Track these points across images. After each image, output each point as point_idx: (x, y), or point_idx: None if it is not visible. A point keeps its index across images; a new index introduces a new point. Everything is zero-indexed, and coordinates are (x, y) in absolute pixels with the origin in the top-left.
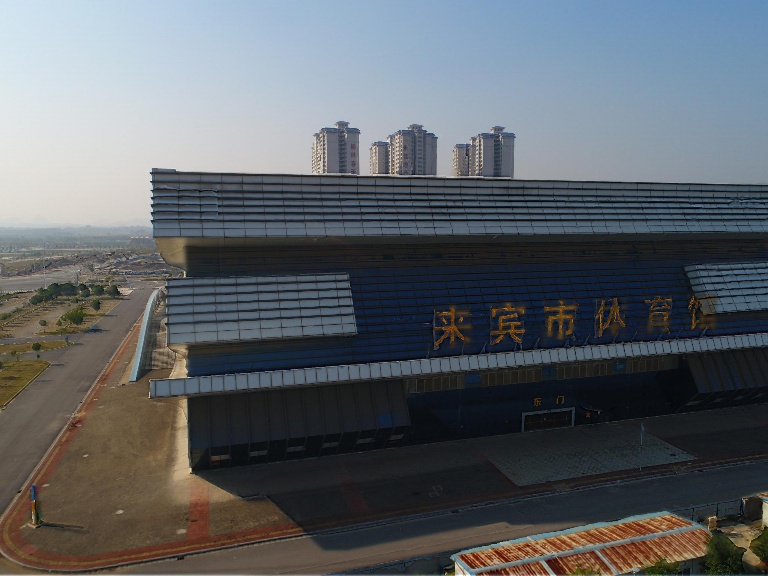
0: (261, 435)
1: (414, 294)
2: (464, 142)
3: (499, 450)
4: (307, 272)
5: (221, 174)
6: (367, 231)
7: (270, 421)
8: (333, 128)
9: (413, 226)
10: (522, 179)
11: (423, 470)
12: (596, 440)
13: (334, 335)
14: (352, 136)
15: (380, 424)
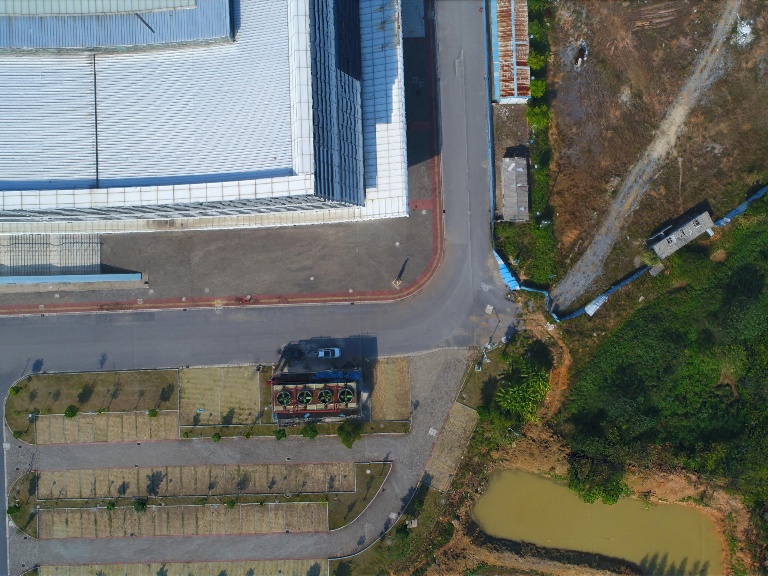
0: None
1: None
2: None
3: None
4: None
5: None
6: None
7: None
8: None
9: None
10: None
11: None
12: None
13: None
14: None
15: None
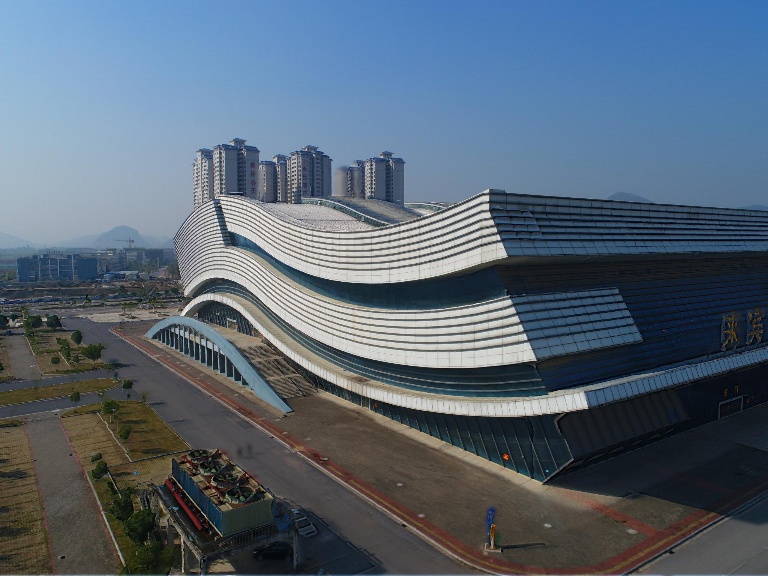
0: (609, 439)
1: (648, 305)
2: (356, 165)
3: (730, 434)
4: (579, 288)
5: (534, 196)
6: (631, 250)
7: (610, 425)
8: (230, 145)
9: (653, 245)
10: (698, 206)
11: (710, 456)
12: None
13: (631, 343)
14: (252, 154)
15: (671, 420)
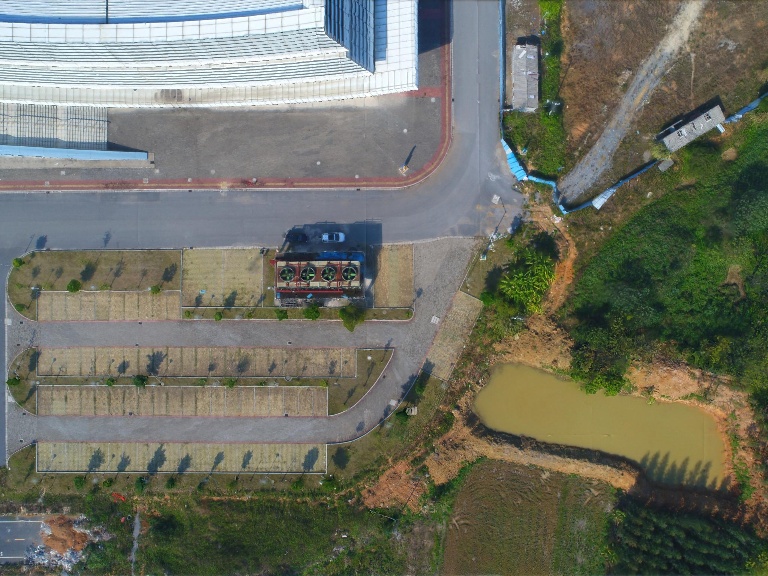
0: None
1: None
2: None
3: None
4: None
5: None
6: None
7: None
8: None
9: None
10: None
11: None
12: None
13: None
14: None
15: None
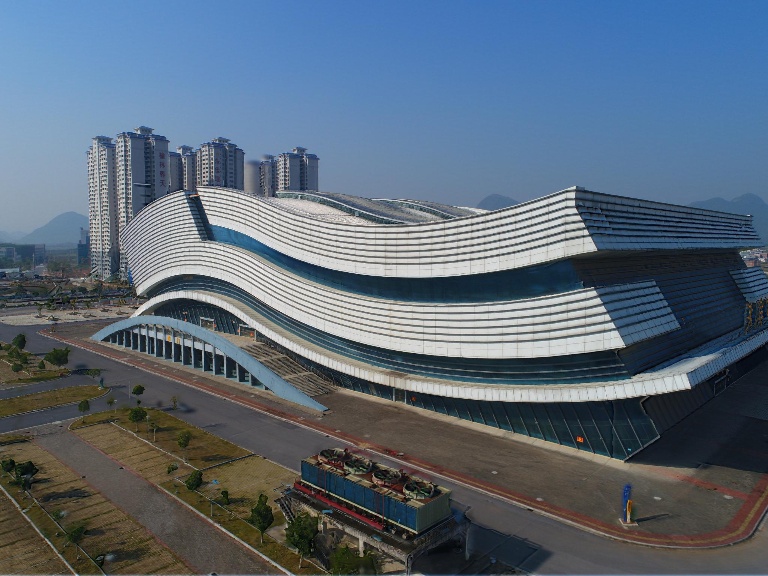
0: (675, 417)
1: (668, 296)
2: (269, 160)
3: (733, 409)
4: (624, 280)
5: (602, 194)
6: (664, 245)
7: None
8: (137, 133)
9: None
10: None
11: (734, 428)
12: (756, 394)
13: None
14: (161, 144)
15: None
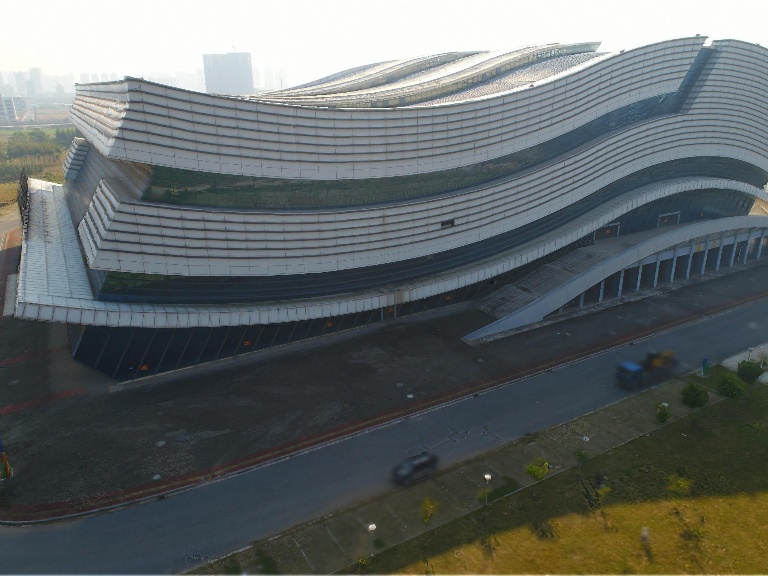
0: None
1: None
2: None
3: None
4: None
5: None
6: None
7: None
8: None
9: None
10: None
11: None
12: None
13: None
14: None
15: None
